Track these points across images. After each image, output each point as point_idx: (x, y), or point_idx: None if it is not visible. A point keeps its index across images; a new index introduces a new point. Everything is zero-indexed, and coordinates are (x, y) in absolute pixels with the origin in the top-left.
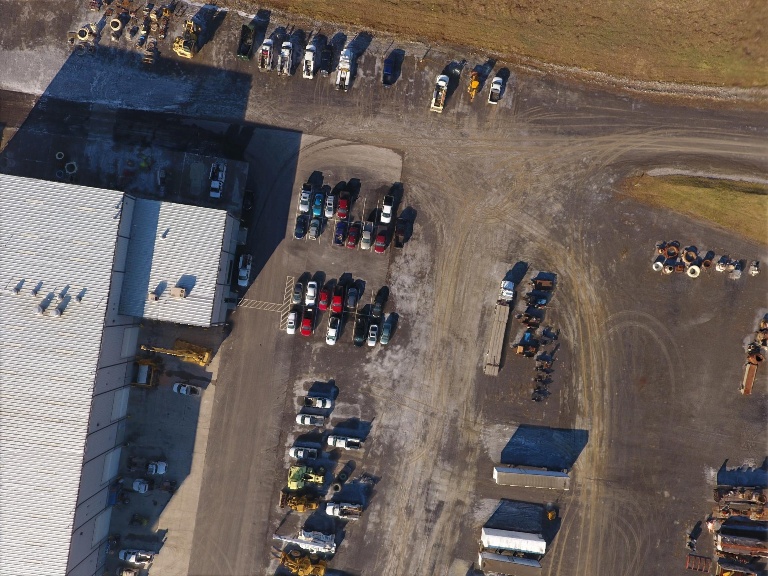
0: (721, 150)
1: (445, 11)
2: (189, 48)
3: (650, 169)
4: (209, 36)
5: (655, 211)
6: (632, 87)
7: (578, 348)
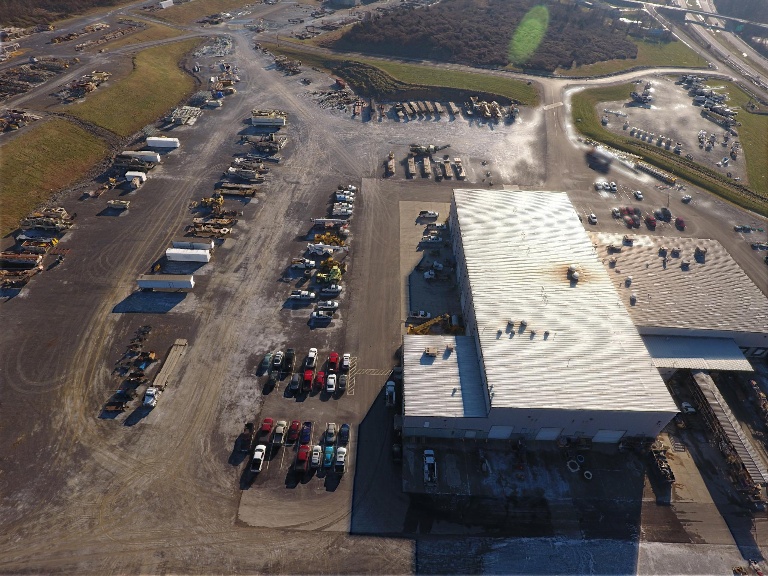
0: None
1: None
2: None
3: None
4: None
5: None
6: None
7: (99, 363)
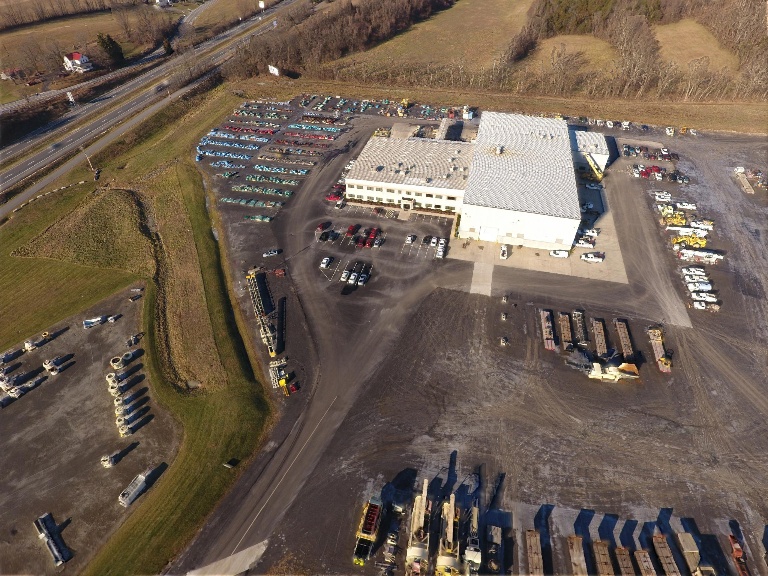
0: None
1: (660, 117)
2: None
3: None
4: None
5: None
6: (753, 134)
7: None
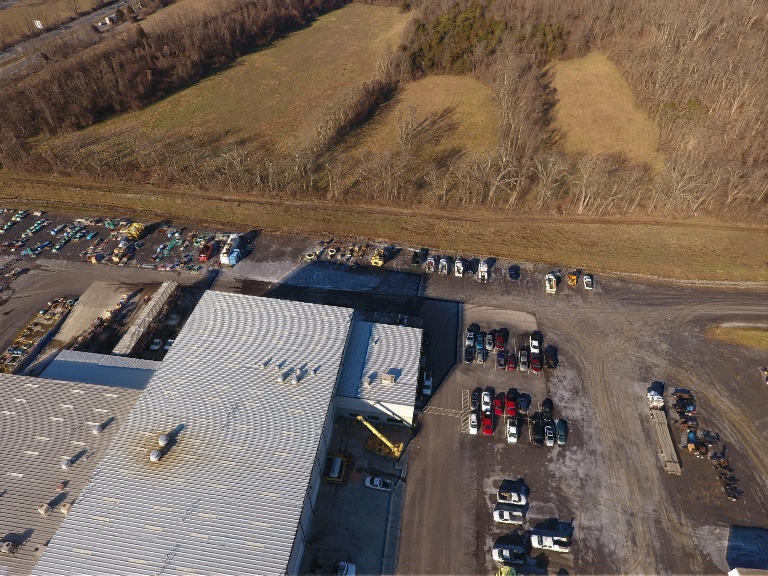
0: (765, 312)
1: (540, 248)
2: (383, 258)
3: (721, 323)
4: (391, 258)
5: (742, 348)
6: (679, 282)
7: (744, 449)
